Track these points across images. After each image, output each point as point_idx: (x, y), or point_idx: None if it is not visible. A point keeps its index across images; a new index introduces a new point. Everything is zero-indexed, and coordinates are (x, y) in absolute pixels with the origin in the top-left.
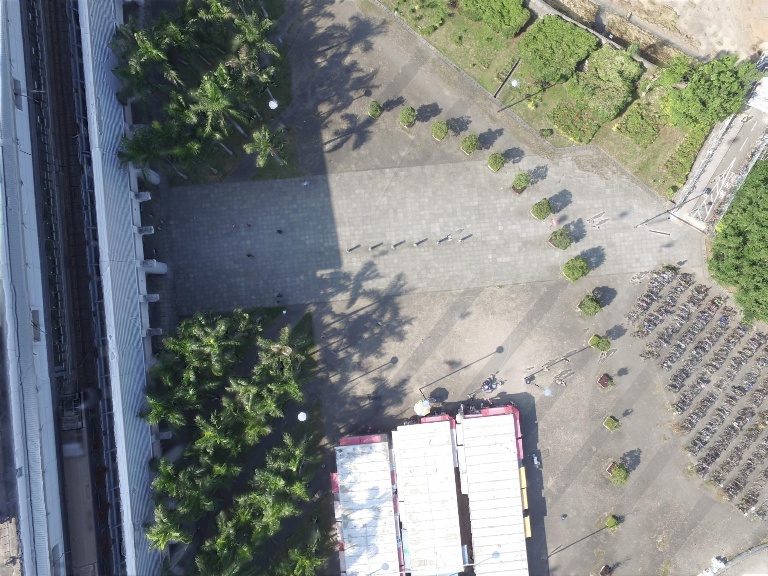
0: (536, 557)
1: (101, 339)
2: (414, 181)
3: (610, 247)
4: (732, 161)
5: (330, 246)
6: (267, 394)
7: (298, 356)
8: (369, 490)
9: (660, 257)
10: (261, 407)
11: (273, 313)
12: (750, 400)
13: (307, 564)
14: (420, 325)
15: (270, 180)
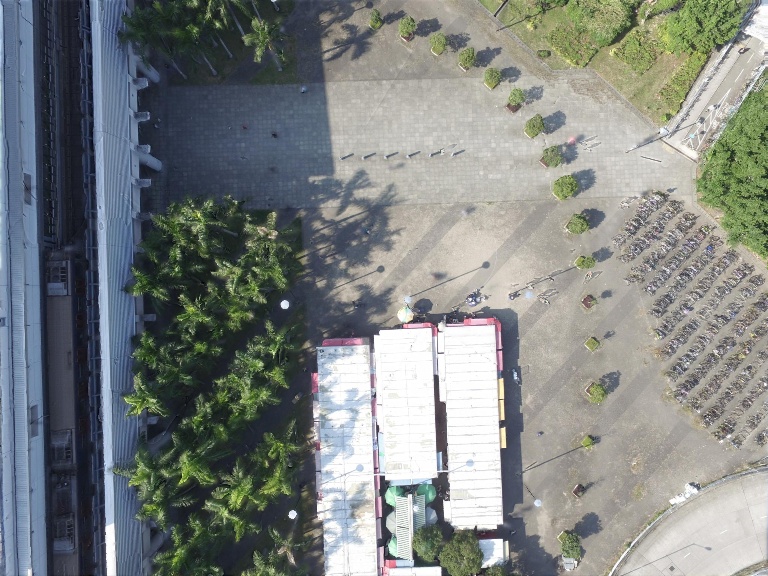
0: (510, 472)
1: (91, 211)
2: (410, 94)
3: (601, 170)
4: (727, 92)
5: (324, 153)
6: (251, 279)
7: (284, 246)
8: (348, 391)
9: (650, 183)
10: (245, 290)
11: (264, 216)
12: (732, 330)
13: (282, 450)
14: (408, 236)
15: (268, 85)
